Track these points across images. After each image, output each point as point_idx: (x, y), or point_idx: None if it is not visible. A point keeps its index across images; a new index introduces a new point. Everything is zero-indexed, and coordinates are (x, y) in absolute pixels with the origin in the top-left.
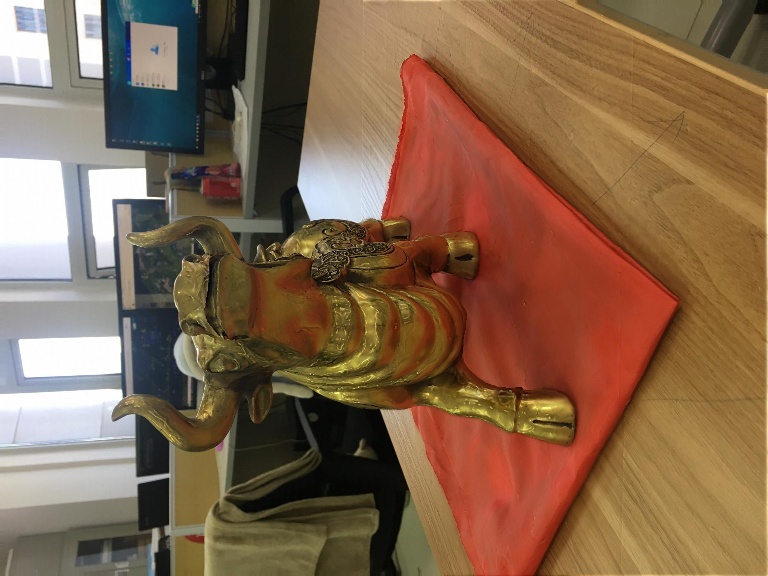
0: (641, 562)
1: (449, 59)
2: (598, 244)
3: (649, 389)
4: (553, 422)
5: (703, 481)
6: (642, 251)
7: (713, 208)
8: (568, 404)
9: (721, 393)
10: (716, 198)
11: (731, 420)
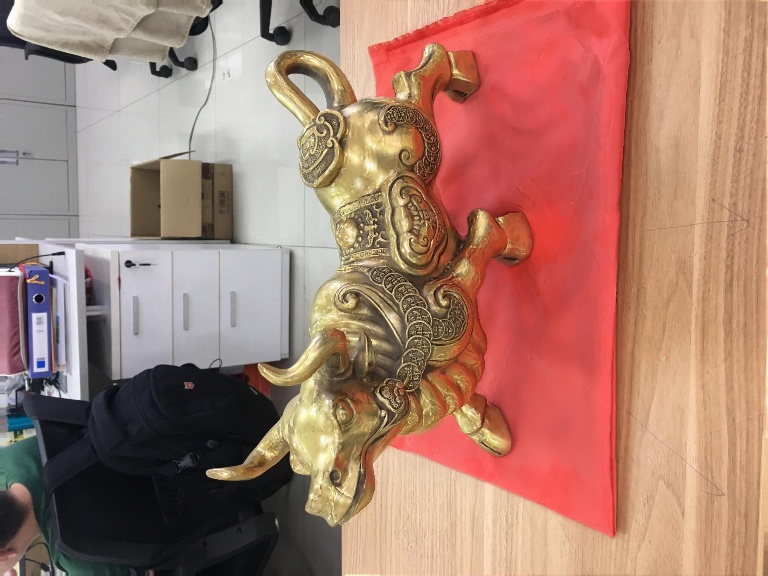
0: (488, 536)
1: (655, 43)
2: (606, 457)
3: (561, 516)
4: (493, 450)
5: (549, 572)
6: (625, 482)
7: (677, 542)
8: (509, 447)
9: (592, 574)
10: (684, 543)
11: None
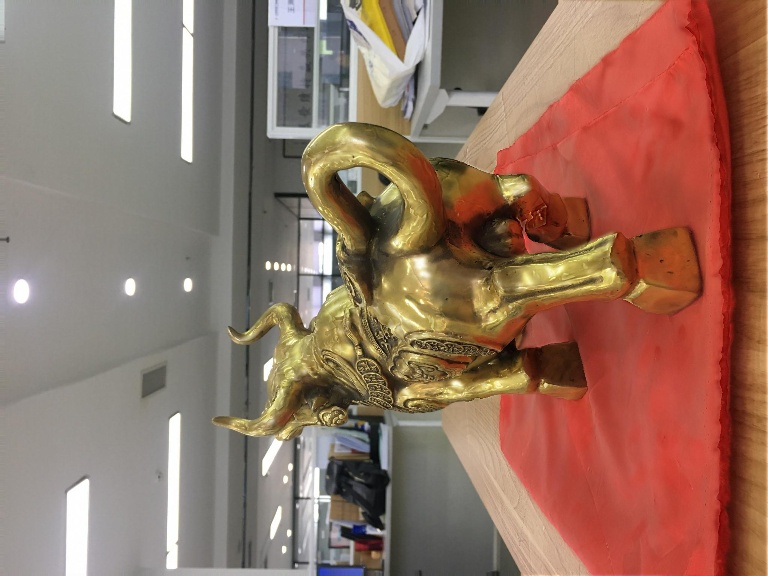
0: None
1: None
2: None
3: None
4: None
5: None
6: None
7: None
8: None
9: None
10: None
11: None
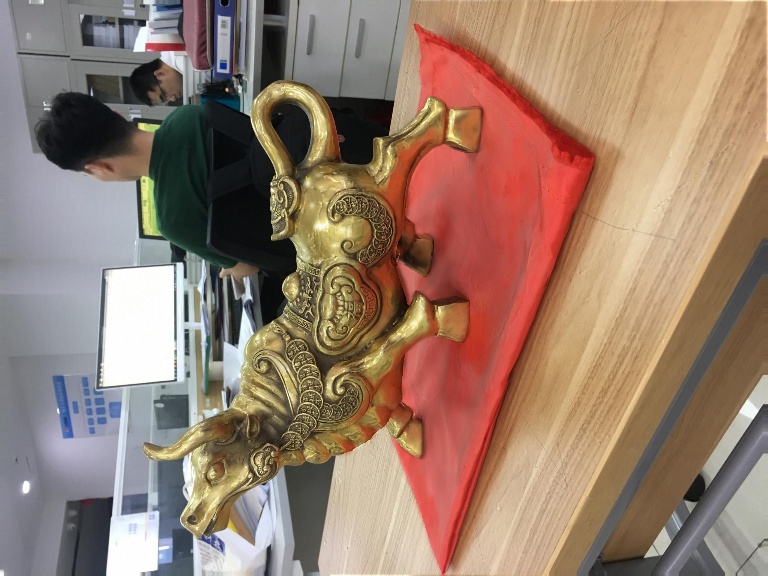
0: None
1: (577, 269)
2: (449, 532)
3: None
4: None
5: None
6: (460, 550)
7: None
8: None
9: (433, 575)
10: None
11: (429, 575)
